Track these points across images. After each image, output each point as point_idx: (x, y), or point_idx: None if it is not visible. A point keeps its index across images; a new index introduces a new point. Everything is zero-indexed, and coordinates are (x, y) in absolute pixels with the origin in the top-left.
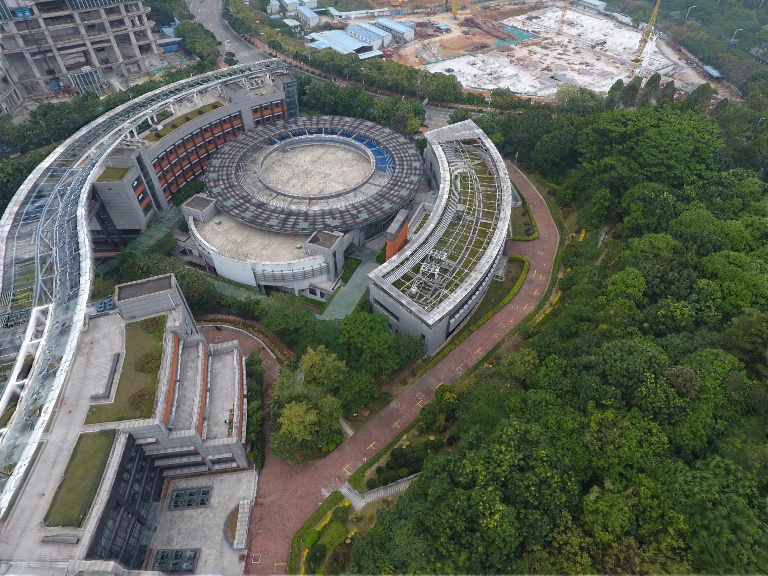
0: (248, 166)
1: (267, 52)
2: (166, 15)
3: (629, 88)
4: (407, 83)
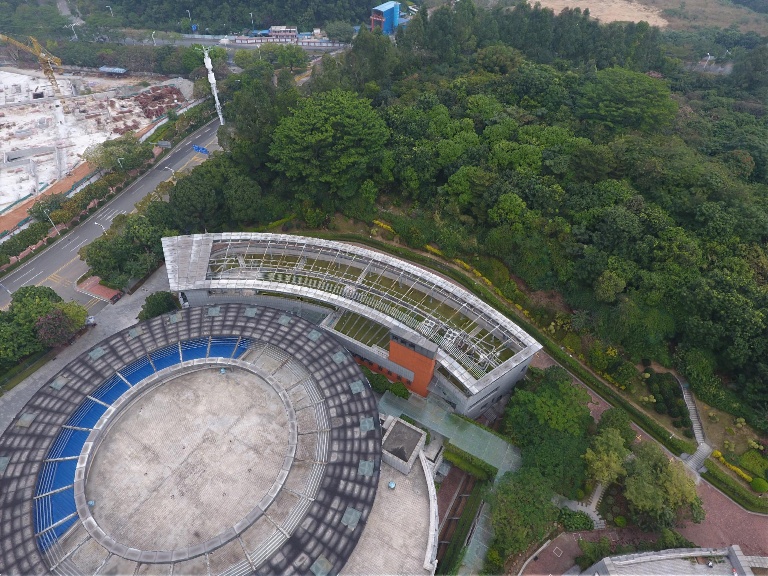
0: None
1: None
2: None
3: (248, 105)
4: None
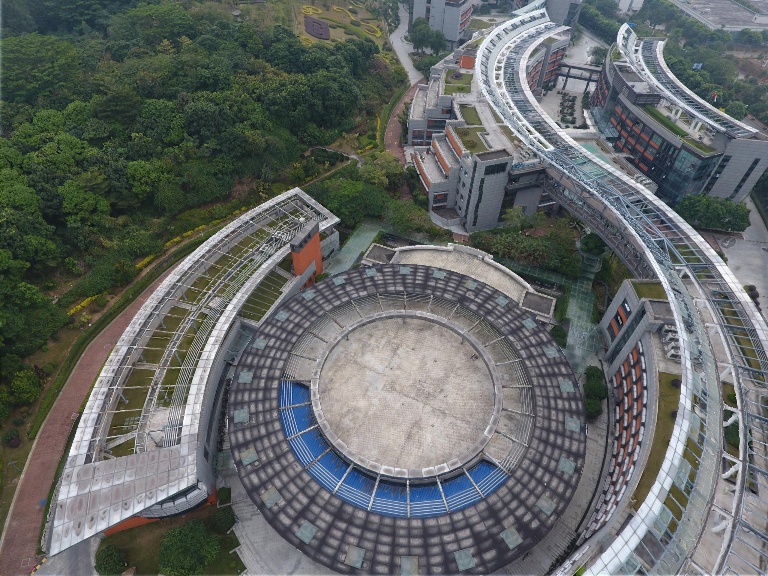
0: None
1: None
2: None
3: None
4: None
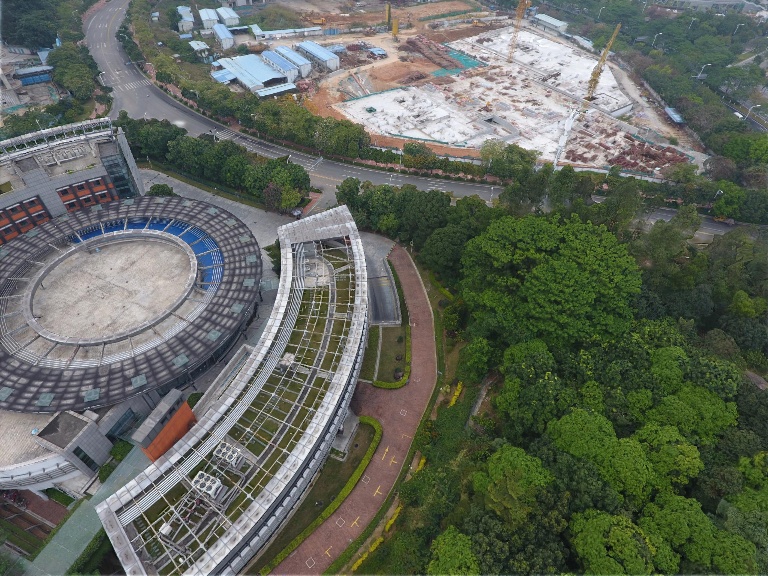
0: (31, 277)
1: (158, 84)
2: (46, 35)
3: (535, 181)
4: (304, 134)
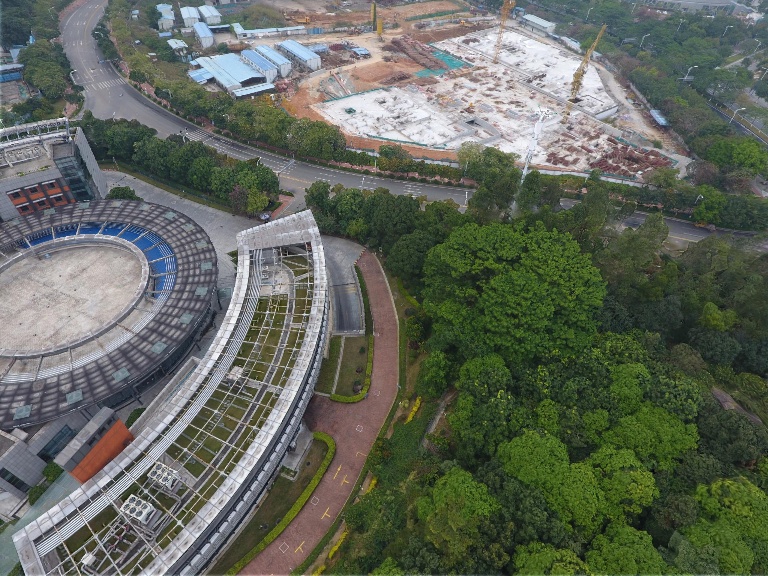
0: None
1: (132, 83)
2: (20, 32)
3: (502, 186)
4: (277, 135)
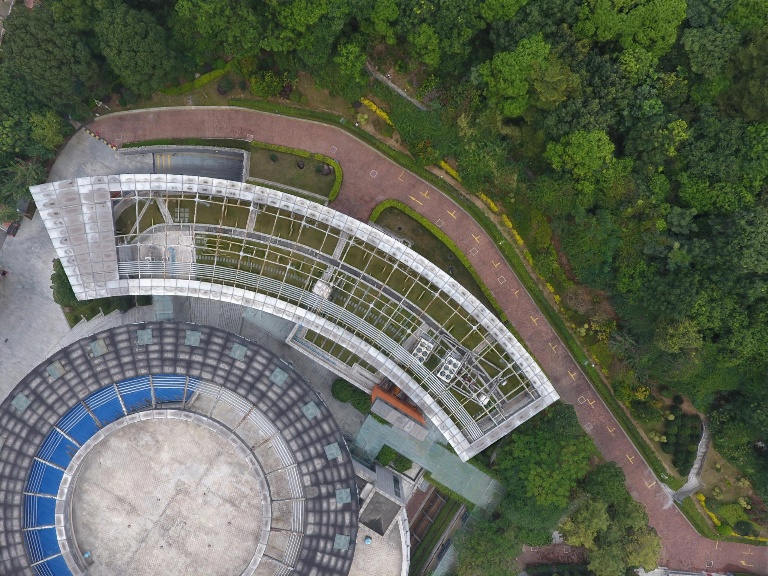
0: None
1: None
2: None
3: None
4: None
